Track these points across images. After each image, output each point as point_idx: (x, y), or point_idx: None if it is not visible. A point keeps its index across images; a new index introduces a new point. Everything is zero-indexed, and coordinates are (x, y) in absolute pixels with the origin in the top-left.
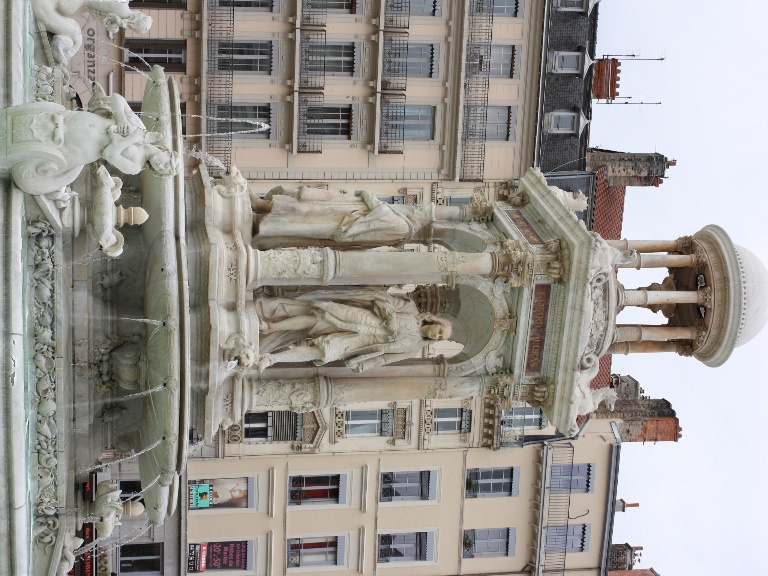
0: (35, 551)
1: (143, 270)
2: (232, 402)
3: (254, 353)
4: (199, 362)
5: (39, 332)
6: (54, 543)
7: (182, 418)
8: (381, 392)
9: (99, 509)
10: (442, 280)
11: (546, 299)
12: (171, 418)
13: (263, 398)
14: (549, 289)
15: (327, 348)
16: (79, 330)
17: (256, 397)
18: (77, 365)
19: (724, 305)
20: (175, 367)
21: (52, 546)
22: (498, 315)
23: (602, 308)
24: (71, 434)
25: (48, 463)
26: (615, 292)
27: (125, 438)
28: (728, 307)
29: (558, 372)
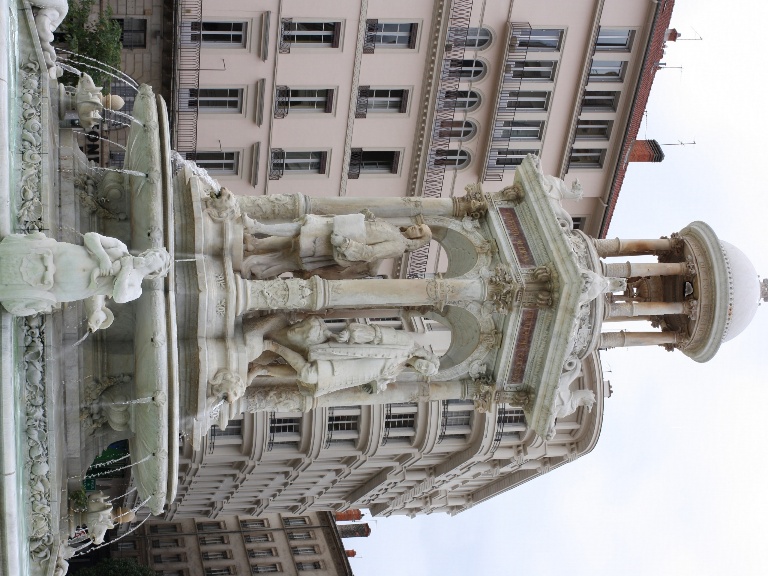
0: None
1: None
2: (225, 279)
3: (235, 198)
4: (183, 211)
5: None
6: None
7: (161, 126)
8: (378, 281)
9: None
10: (412, 222)
11: (514, 217)
12: (150, 110)
13: (257, 284)
14: (513, 211)
15: None
16: (65, 151)
17: (250, 283)
18: (63, 172)
19: (696, 240)
20: None
21: None
22: (477, 245)
23: None
24: (57, 238)
25: (32, 157)
26: None
27: (121, 394)
28: (699, 237)
29: (549, 246)
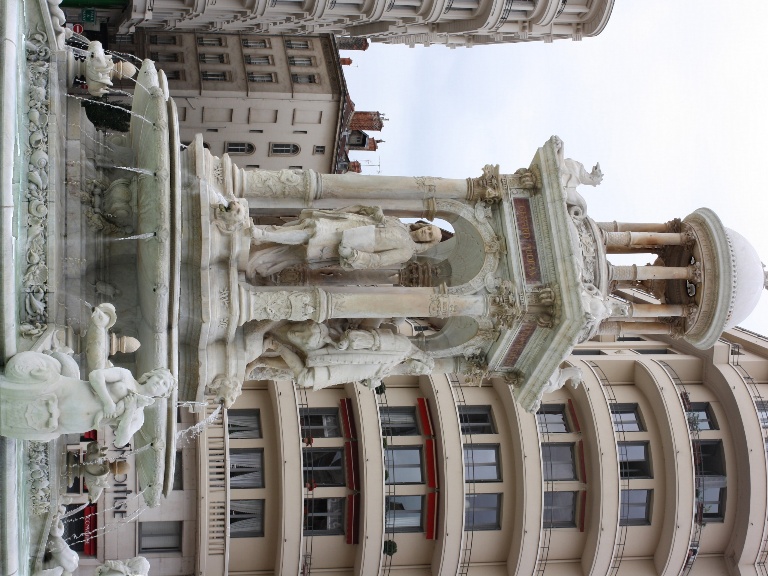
0: (20, 339)
1: (133, 164)
2: (229, 296)
3: (244, 208)
4: (191, 221)
5: (34, 88)
6: (42, 334)
7: (173, 167)
8: (382, 298)
9: (91, 320)
10: (423, 206)
11: (527, 212)
12: (161, 152)
13: (261, 299)
14: (528, 203)
15: (317, 222)
16: (72, 152)
17: (254, 298)
18: (69, 184)
19: (708, 239)
20: (163, 115)
21: (39, 336)
22: (486, 240)
23: (587, 233)
24: (62, 269)
25: (38, 209)
26: (596, 226)
27: None
28: (712, 237)
29: (557, 265)
